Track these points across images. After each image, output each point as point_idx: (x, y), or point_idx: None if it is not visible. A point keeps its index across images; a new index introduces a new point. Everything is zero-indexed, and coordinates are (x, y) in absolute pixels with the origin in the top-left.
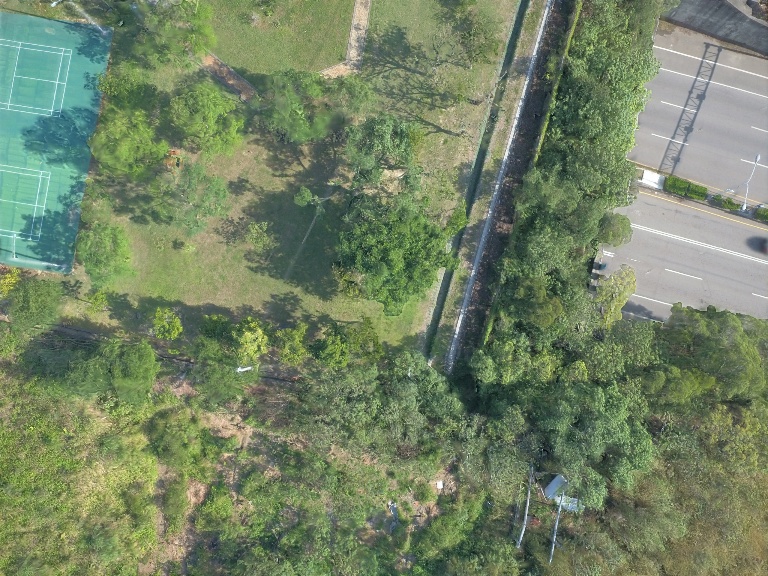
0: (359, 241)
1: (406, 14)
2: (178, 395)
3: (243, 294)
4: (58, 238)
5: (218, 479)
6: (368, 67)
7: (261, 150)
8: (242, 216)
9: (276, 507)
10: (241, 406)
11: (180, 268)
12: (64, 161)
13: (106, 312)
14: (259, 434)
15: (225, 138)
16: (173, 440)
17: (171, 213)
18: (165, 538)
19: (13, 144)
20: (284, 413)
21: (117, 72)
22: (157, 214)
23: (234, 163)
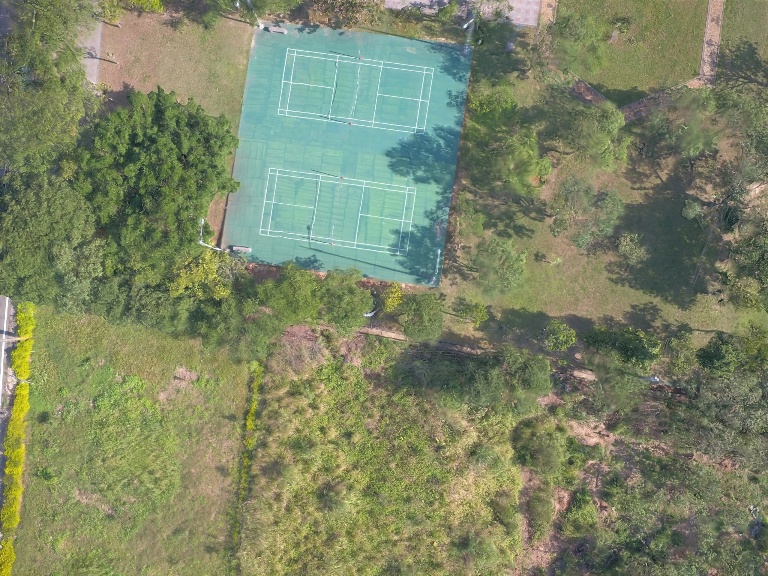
0: (759, 252)
1: (757, 30)
2: (543, 404)
3: (604, 305)
4: (426, 252)
5: (581, 486)
6: (721, 82)
7: (620, 164)
8: (602, 228)
9: (640, 513)
10: (610, 414)
11: (542, 280)
12: (431, 177)
13: (469, 324)
14: (621, 441)
15: (618, 153)
16: (550, 448)
17: (533, 226)
18: (531, 544)
19: (379, 161)
20: (656, 421)
21: (477, 89)
22: (519, 227)
23: (594, 177)
